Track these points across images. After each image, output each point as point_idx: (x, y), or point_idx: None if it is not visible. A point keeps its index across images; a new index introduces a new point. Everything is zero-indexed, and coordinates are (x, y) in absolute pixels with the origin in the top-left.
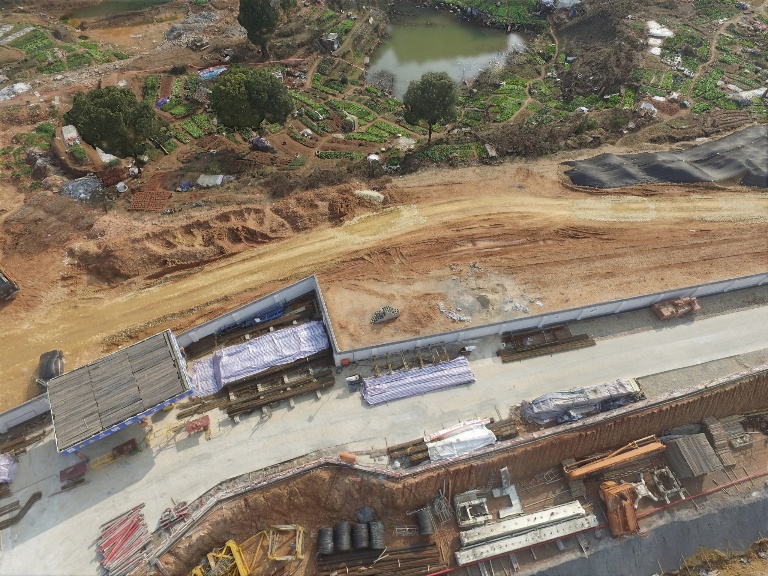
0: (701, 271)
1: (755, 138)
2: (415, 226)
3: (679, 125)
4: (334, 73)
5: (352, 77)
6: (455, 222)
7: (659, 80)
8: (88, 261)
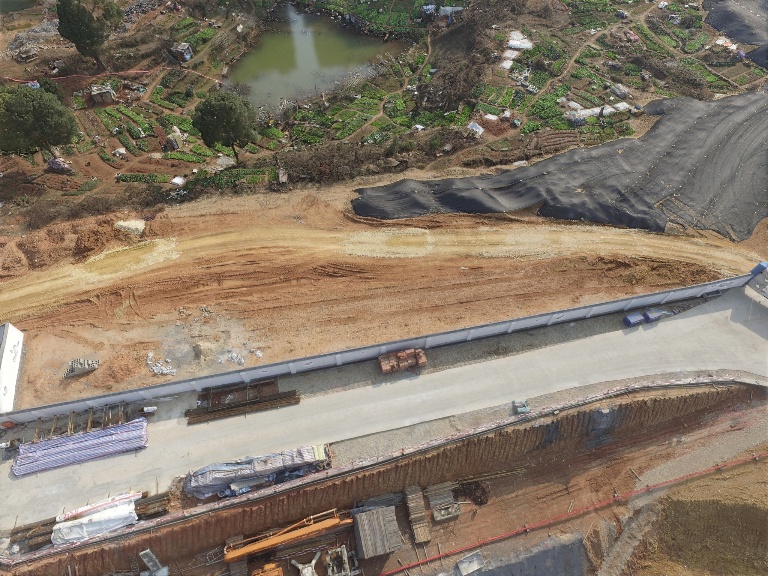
0: (452, 316)
1: (566, 163)
2: (164, 262)
3: (501, 147)
4: (180, 85)
5: (201, 89)
6: (210, 258)
7: (498, 97)
8: None
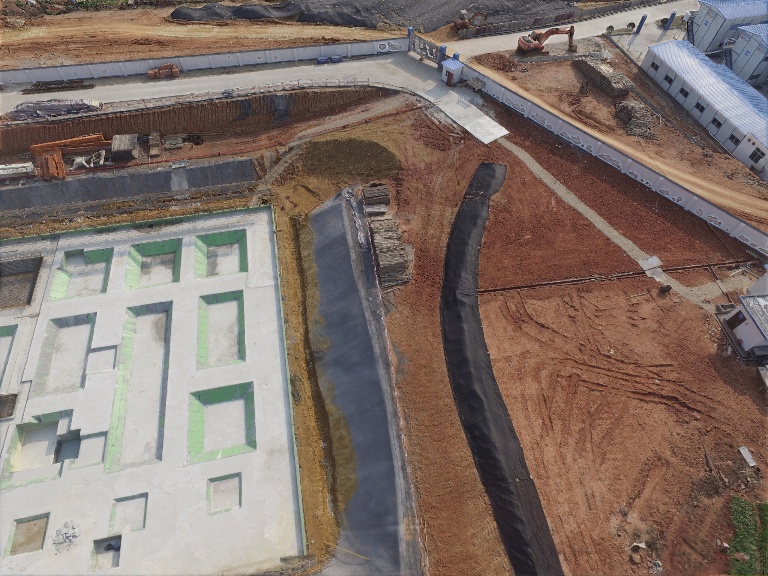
0: None
1: None
2: (34, 37)
3: None
4: None
5: None
6: (65, 35)
7: None
8: None
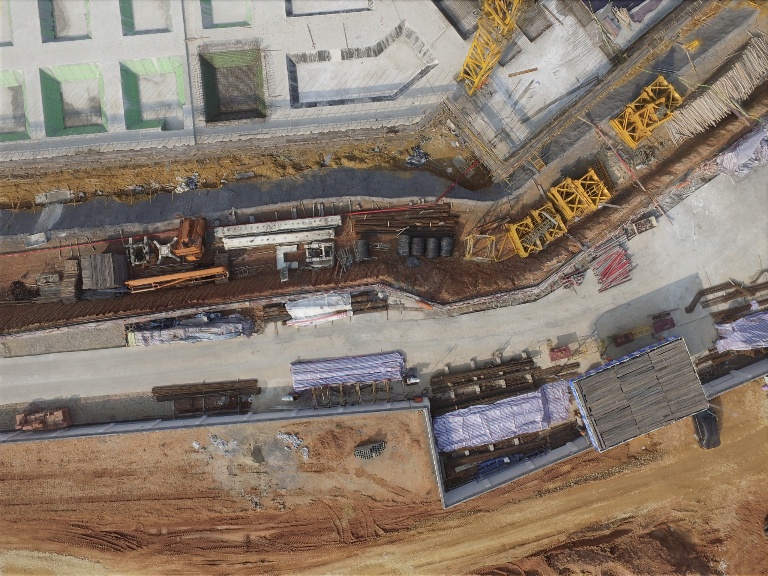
0: None
1: None
2: (314, 574)
3: None
4: None
5: None
6: (263, 575)
7: None
8: (699, 563)
